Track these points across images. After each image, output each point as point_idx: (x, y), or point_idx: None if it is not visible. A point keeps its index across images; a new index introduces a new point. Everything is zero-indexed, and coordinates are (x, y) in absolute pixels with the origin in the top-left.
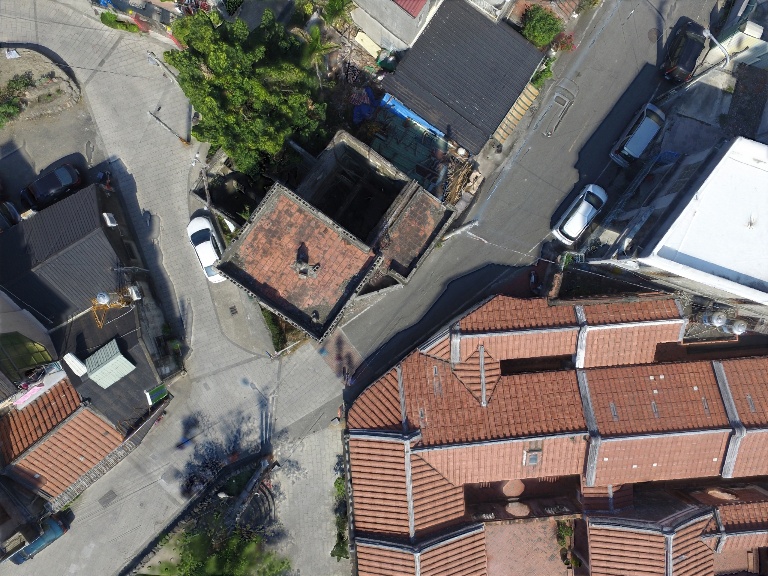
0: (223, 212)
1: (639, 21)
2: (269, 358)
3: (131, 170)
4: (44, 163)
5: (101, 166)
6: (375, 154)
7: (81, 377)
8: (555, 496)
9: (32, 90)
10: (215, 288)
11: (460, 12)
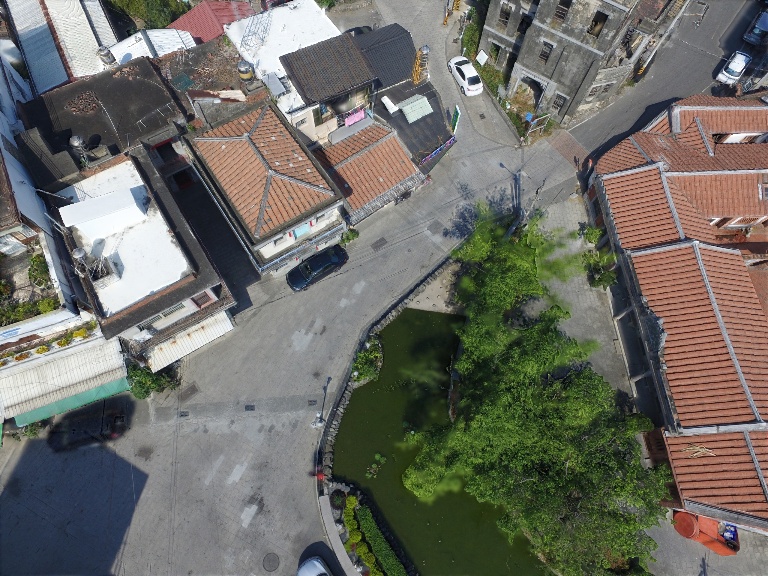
0: None
1: None
2: (513, 147)
3: None
4: None
5: None
6: None
7: (392, 114)
8: None
9: None
10: (467, 102)
11: None
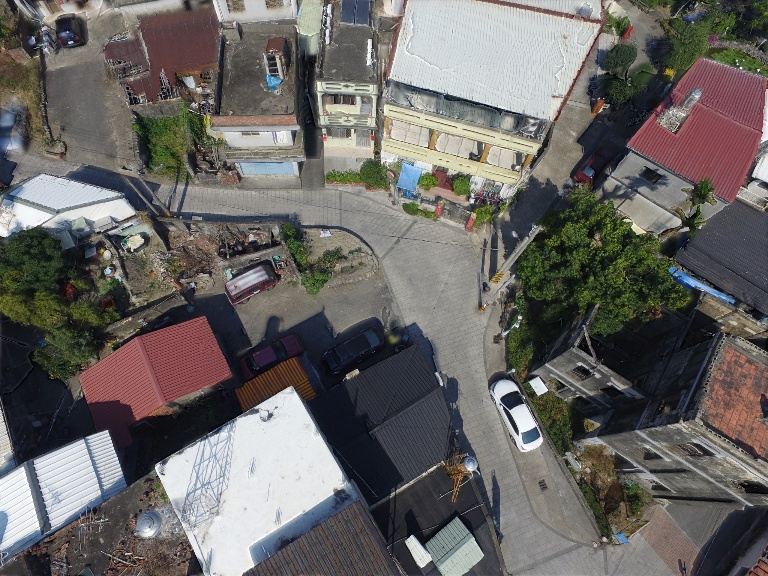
0: None
1: None
2: (591, 547)
3: (426, 334)
4: (341, 327)
5: (397, 330)
6: (742, 313)
7: (422, 568)
8: None
9: (343, 262)
10: (520, 458)
11: None
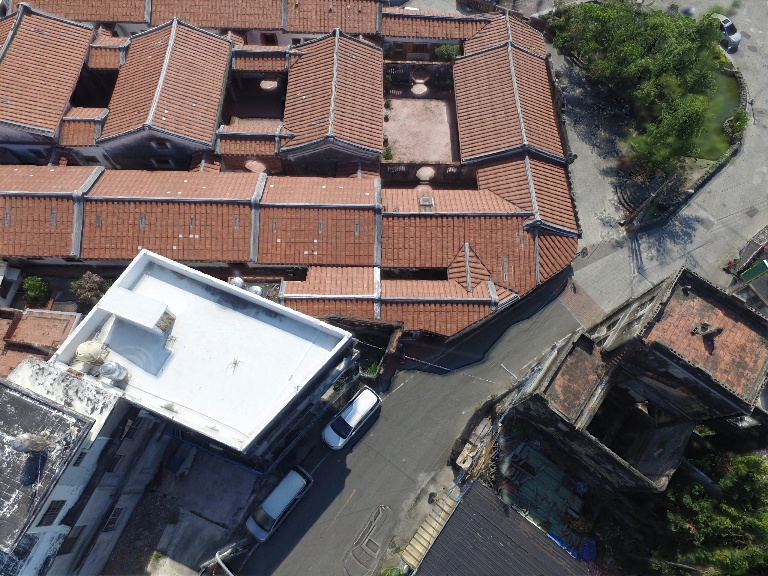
0: (754, 417)
1: None
2: None
3: None
4: None
5: None
6: (623, 461)
7: None
8: (389, 182)
9: None
10: None
11: None
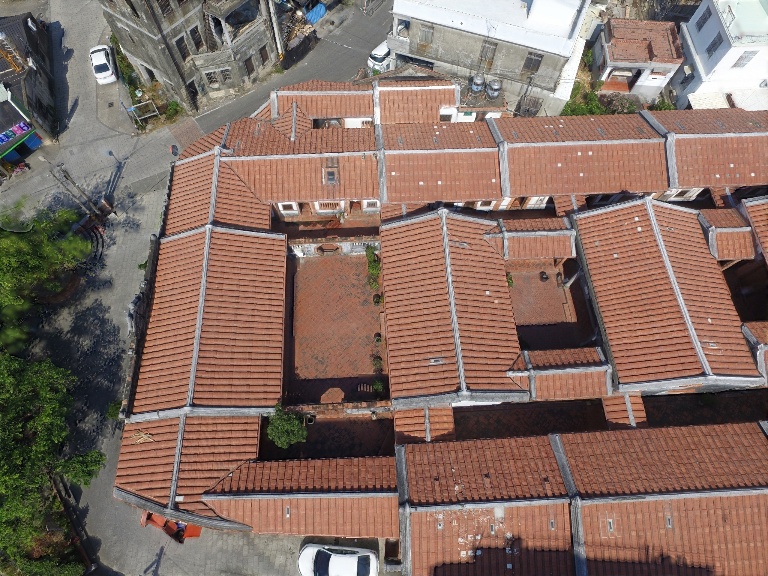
0: None
1: None
2: (130, 135)
3: (64, 27)
4: None
5: None
6: None
7: None
8: None
9: None
10: (101, 91)
11: None
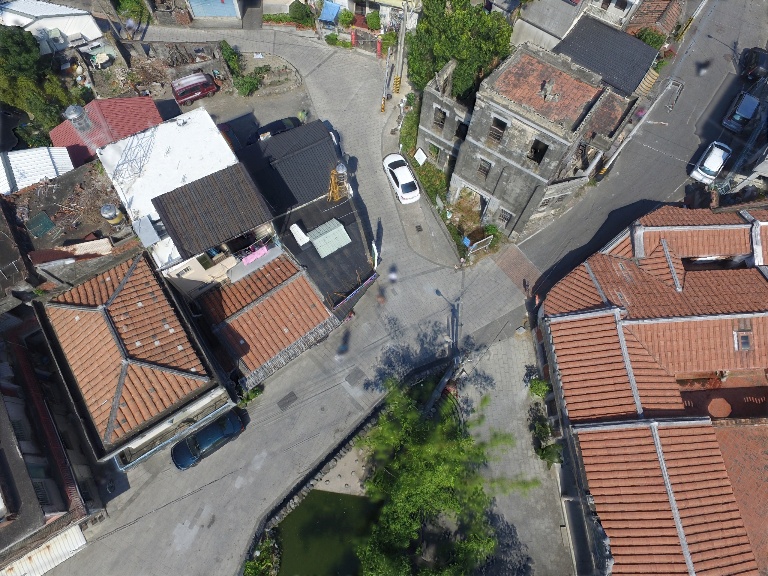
0: None
1: (714, 50)
2: (453, 268)
3: (336, 128)
4: (267, 123)
5: None
6: None
7: (302, 247)
8: None
9: (270, 74)
10: (403, 210)
11: (592, 25)
